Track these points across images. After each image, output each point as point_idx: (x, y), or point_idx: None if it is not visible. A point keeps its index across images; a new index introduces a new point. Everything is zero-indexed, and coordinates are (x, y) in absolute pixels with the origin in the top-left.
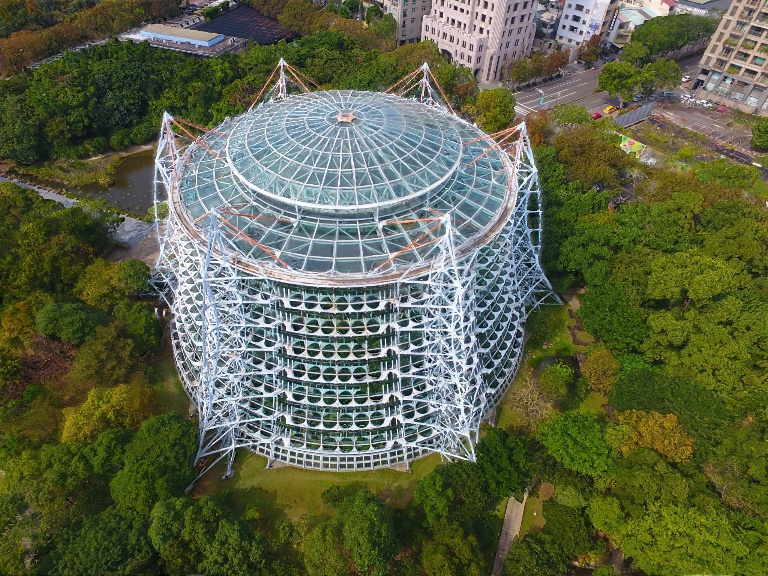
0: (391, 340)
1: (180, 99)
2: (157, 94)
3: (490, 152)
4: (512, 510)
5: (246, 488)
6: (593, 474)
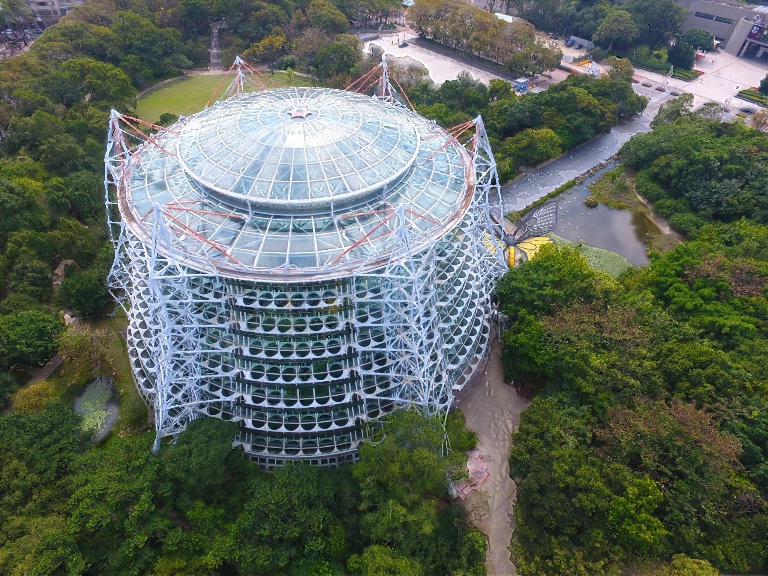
0: None
1: (760, 242)
2: (764, 222)
3: (224, 257)
4: None
5: None
6: None
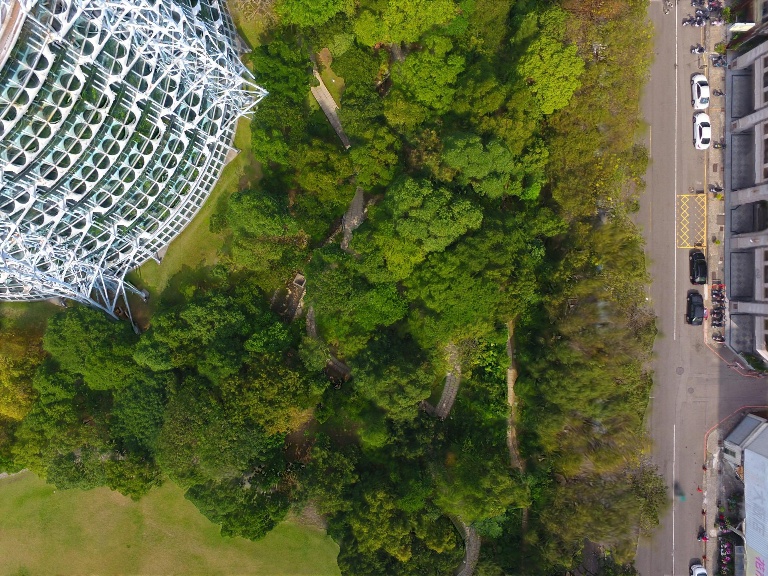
0: (100, 76)
1: None
2: None
3: None
4: (320, 96)
5: (166, 287)
6: (340, 8)
